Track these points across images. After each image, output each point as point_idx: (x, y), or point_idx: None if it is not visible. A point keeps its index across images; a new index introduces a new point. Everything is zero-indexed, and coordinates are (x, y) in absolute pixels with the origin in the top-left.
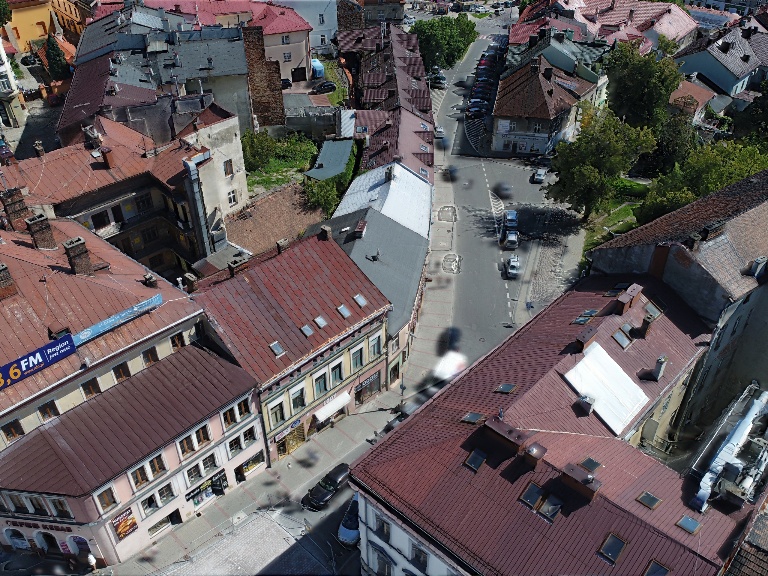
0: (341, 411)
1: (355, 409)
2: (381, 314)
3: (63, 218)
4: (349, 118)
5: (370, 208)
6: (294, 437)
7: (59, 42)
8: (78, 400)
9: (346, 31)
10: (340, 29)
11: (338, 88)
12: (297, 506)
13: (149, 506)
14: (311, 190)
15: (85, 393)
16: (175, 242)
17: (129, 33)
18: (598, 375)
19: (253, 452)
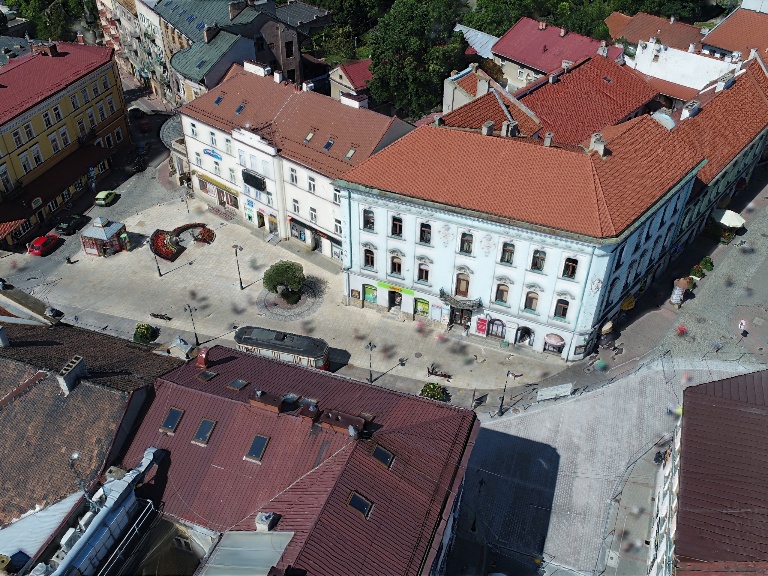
0: None
1: None
2: None
3: None
4: None
5: None
6: None
7: None
8: None
9: None
10: None
11: None
12: None
13: None
14: None
15: None
16: None
17: None
18: (253, 571)
19: None
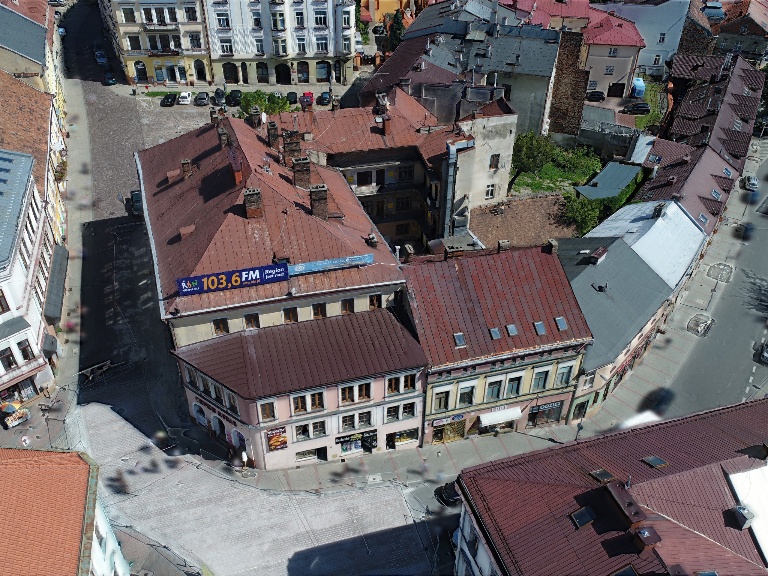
0: (510, 424)
1: (525, 428)
2: (579, 344)
3: (332, 168)
4: (646, 144)
5: (619, 238)
6: (453, 429)
7: (406, 18)
8: (278, 321)
9: (685, 55)
10: (680, 52)
11: (653, 112)
12: (429, 492)
13: (303, 433)
14: (572, 205)
15: (285, 317)
16: (423, 217)
17: (457, 19)
18: None
19: (408, 426)
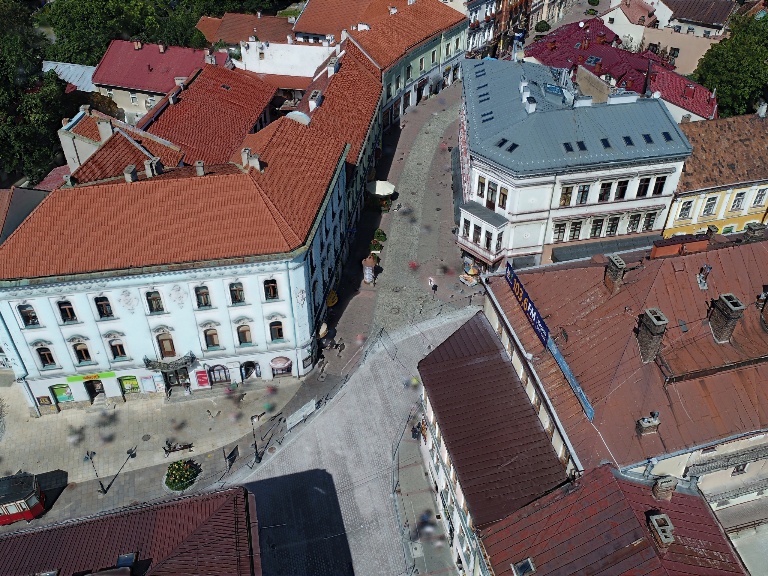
0: None
1: None
2: None
3: None
4: None
5: None
6: None
7: None
8: None
9: None
10: None
11: None
12: None
13: None
14: None
15: None
16: None
17: None
18: None
19: None
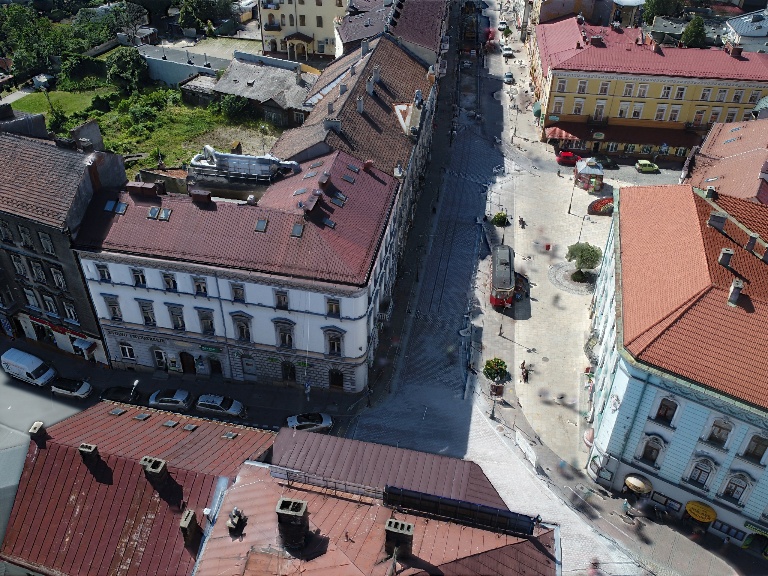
0: None
1: None
2: None
3: None
4: None
5: None
6: None
7: None
8: None
9: None
10: None
11: None
12: None
13: None
14: None
15: None
16: None
17: None
18: None
19: None
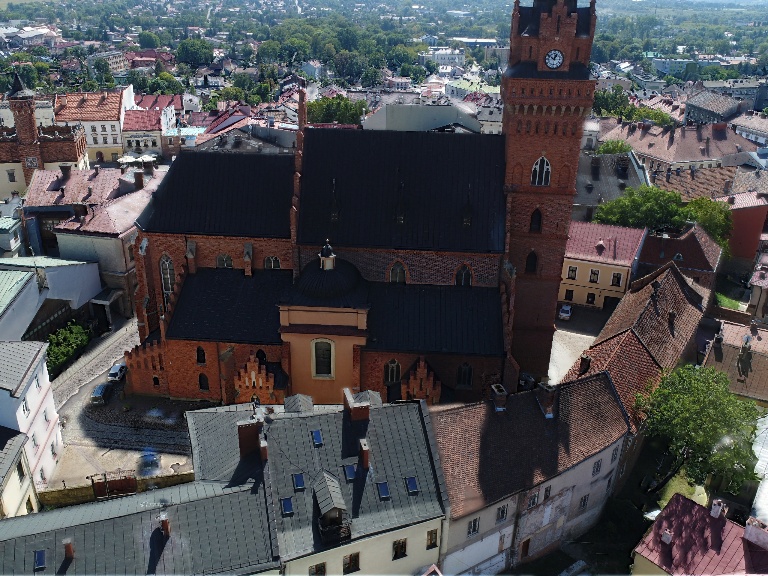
0: None
1: None
2: None
3: None
4: None
5: None
6: None
7: None
8: None
9: None
10: None
11: None
12: None
13: None
14: None
15: None
16: None
17: None
18: None
19: None
